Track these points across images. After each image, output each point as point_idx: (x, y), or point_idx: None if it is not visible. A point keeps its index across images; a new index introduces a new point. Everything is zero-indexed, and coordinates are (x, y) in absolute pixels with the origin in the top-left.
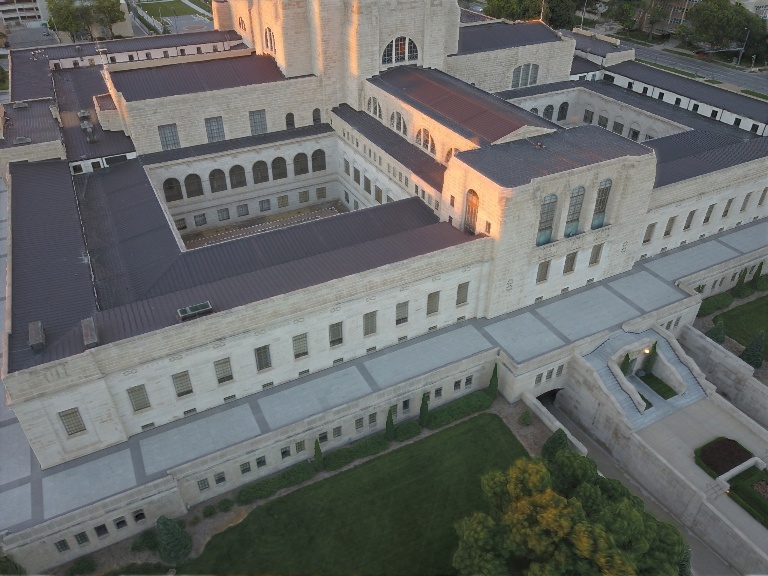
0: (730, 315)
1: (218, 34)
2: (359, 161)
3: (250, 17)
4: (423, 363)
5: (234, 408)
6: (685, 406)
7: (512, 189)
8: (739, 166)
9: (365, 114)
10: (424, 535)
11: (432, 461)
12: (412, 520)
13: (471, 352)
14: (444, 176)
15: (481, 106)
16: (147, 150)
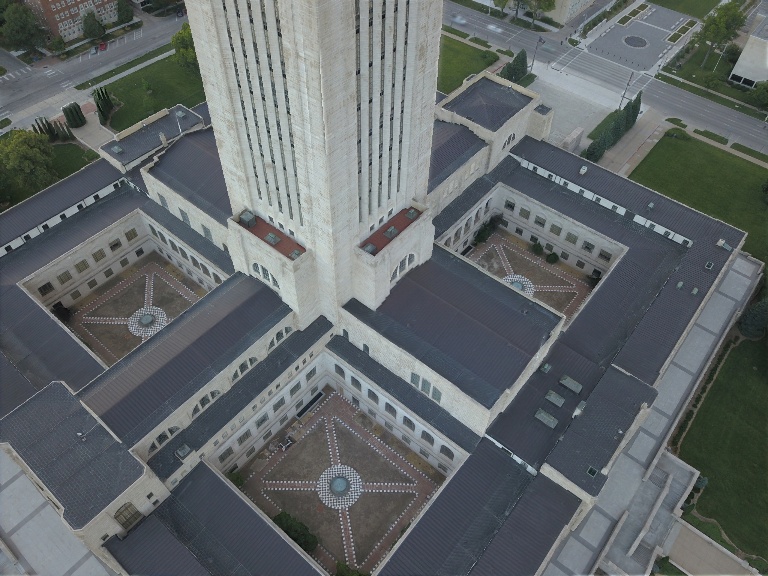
0: None
1: None
2: None
3: None
4: None
5: None
6: None
7: None
8: None
9: None
10: None
11: None
12: None
13: None
14: None
15: (152, 373)
16: None
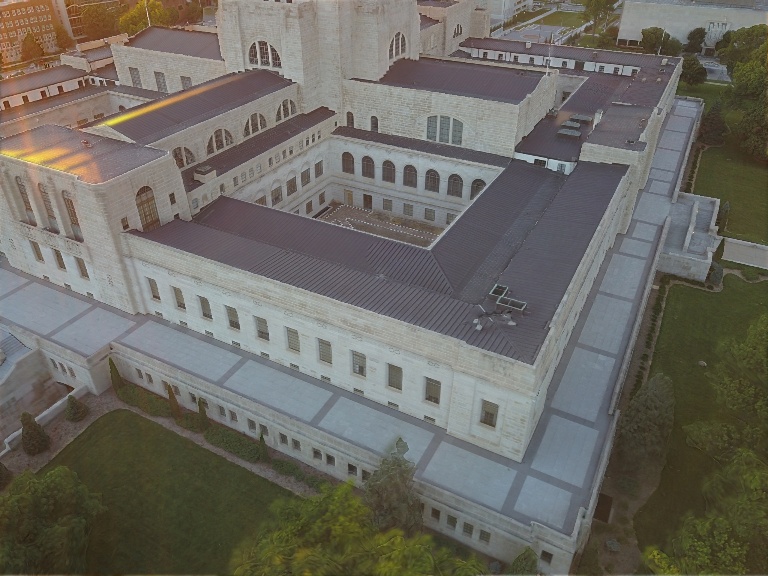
0: (135, 420)
1: None
2: None
3: None
4: None
5: None
6: None
7: None
8: (246, 274)
9: None
10: None
11: None
12: None
13: None
14: None
15: None
16: (125, 82)
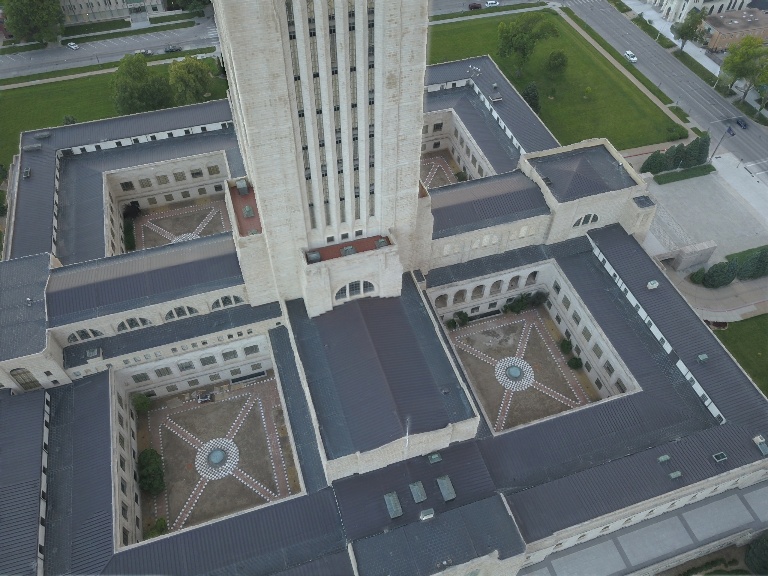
0: None
1: None
2: None
3: None
4: None
5: None
6: None
7: None
8: None
9: None
10: None
11: None
12: None
13: None
14: None
15: (104, 280)
16: None
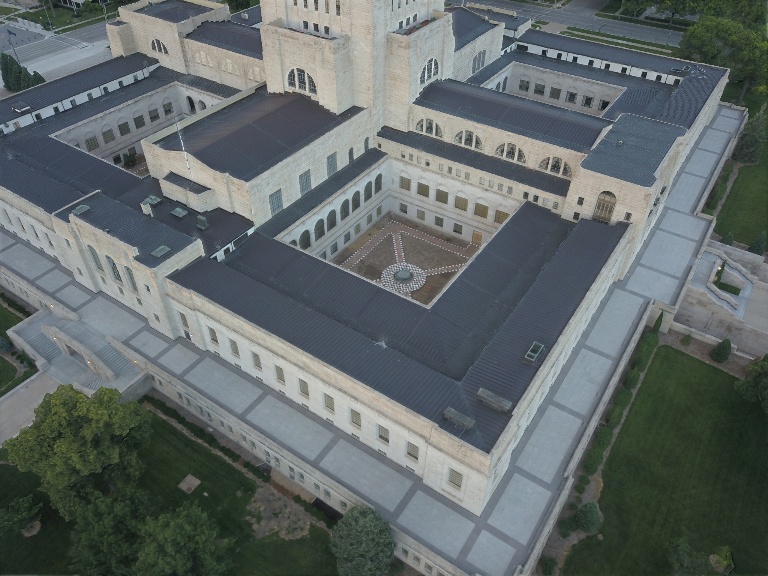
0: (719, 224)
1: (127, 60)
2: (431, 178)
3: (180, 41)
4: (619, 328)
5: (546, 412)
6: (749, 296)
7: (653, 187)
8: (698, 119)
9: (414, 134)
10: (702, 438)
11: (662, 392)
12: (688, 433)
13: (637, 309)
14: (571, 184)
15: (548, 116)
16: (261, 221)
